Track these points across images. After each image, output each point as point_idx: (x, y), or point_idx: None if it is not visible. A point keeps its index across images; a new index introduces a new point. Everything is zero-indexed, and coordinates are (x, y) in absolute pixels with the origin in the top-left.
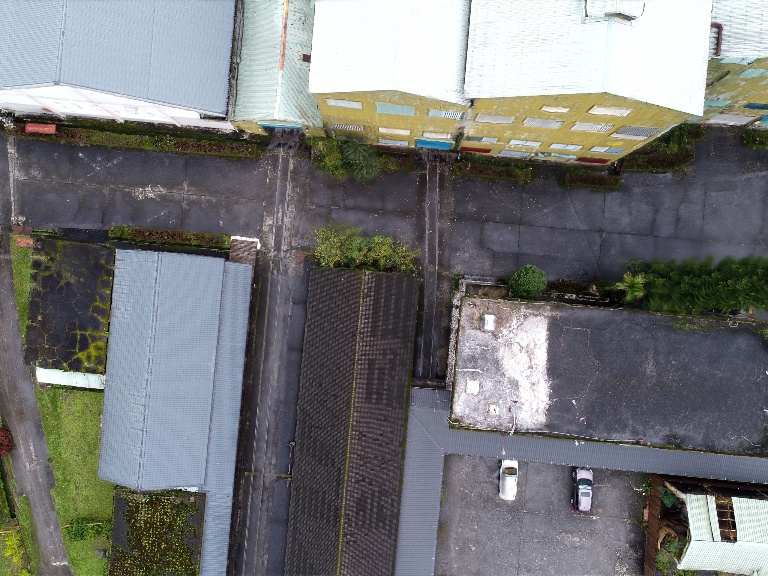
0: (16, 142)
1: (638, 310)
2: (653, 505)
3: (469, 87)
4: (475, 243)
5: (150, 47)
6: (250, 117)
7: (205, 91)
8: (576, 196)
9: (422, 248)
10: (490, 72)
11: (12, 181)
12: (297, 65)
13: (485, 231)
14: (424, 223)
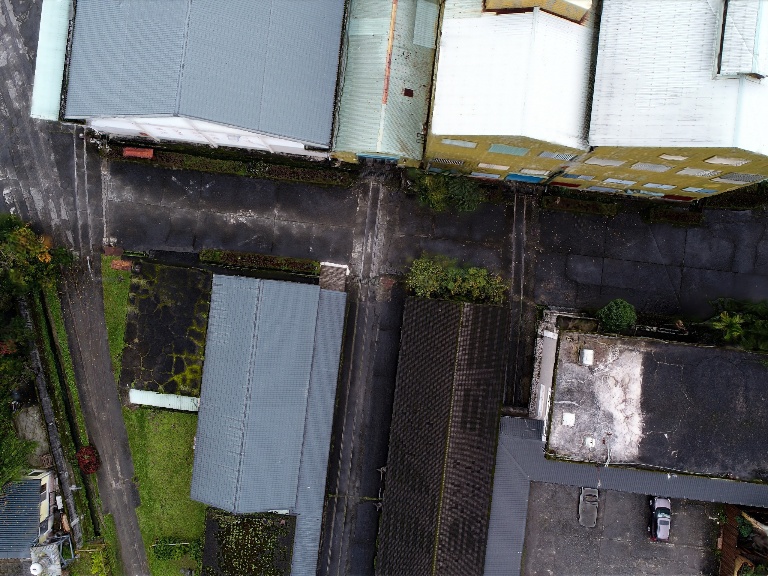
0: (109, 164)
1: (731, 348)
2: (728, 534)
3: (594, 135)
4: (560, 275)
5: (262, 80)
6: (351, 148)
7: (311, 123)
8: (659, 231)
9: (508, 278)
10: (616, 121)
11: (105, 202)
12: (399, 99)
13: (570, 263)
14: (510, 254)
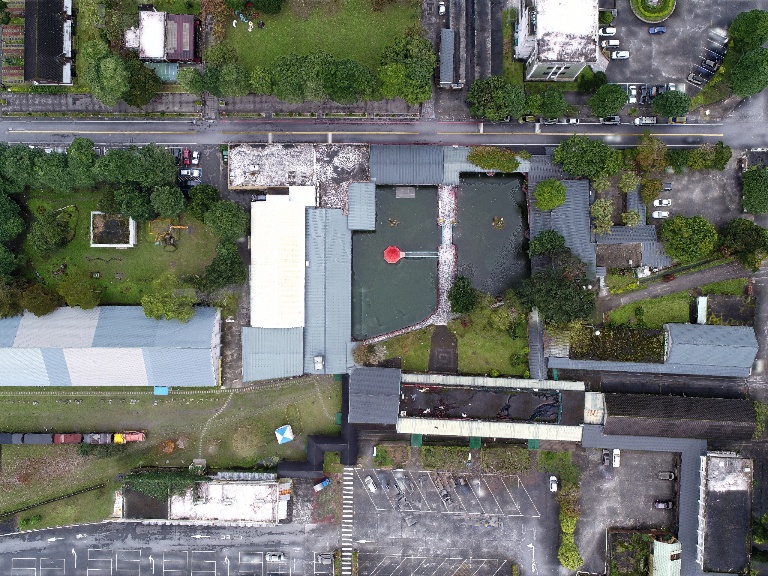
0: None
1: None
2: (660, 532)
3: None
4: (754, 459)
5: None
6: None
7: None
8: None
9: (751, 438)
10: None
11: None
12: None
13: (759, 463)
14: (761, 439)
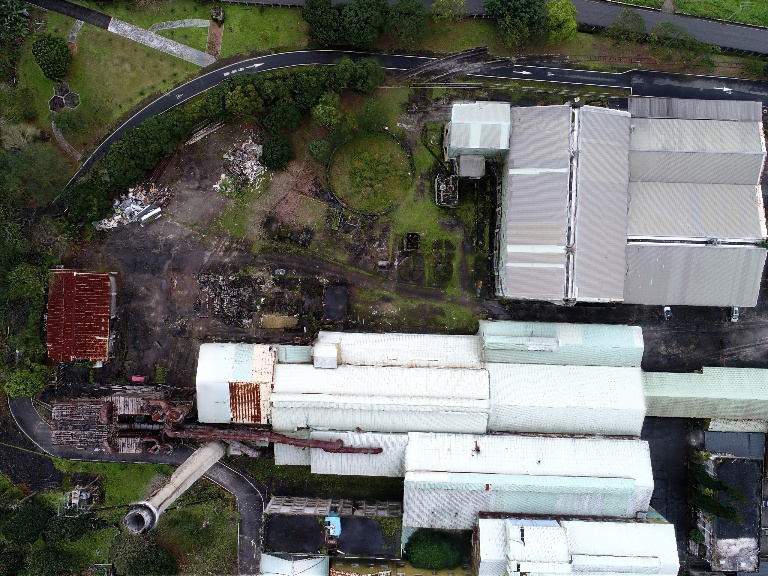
0: None
1: None
2: None
3: None
4: None
5: None
6: None
7: None
8: None
9: None
10: None
11: None
12: None
13: None
14: None
